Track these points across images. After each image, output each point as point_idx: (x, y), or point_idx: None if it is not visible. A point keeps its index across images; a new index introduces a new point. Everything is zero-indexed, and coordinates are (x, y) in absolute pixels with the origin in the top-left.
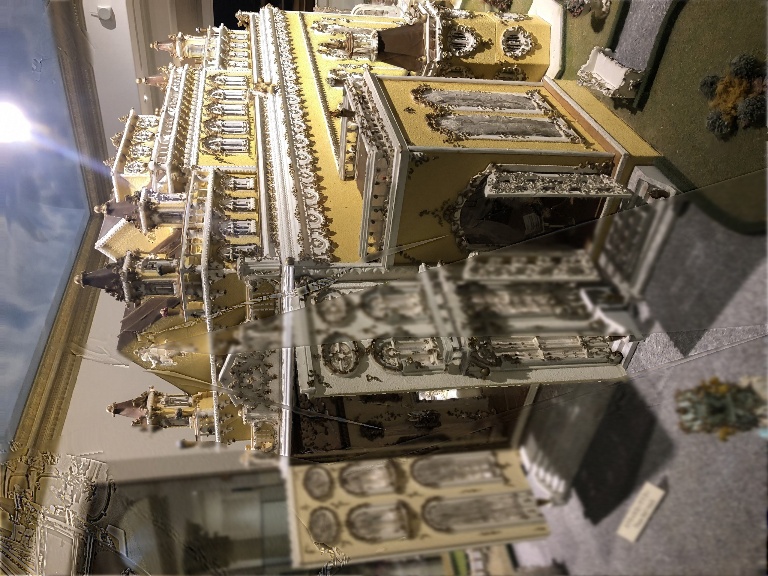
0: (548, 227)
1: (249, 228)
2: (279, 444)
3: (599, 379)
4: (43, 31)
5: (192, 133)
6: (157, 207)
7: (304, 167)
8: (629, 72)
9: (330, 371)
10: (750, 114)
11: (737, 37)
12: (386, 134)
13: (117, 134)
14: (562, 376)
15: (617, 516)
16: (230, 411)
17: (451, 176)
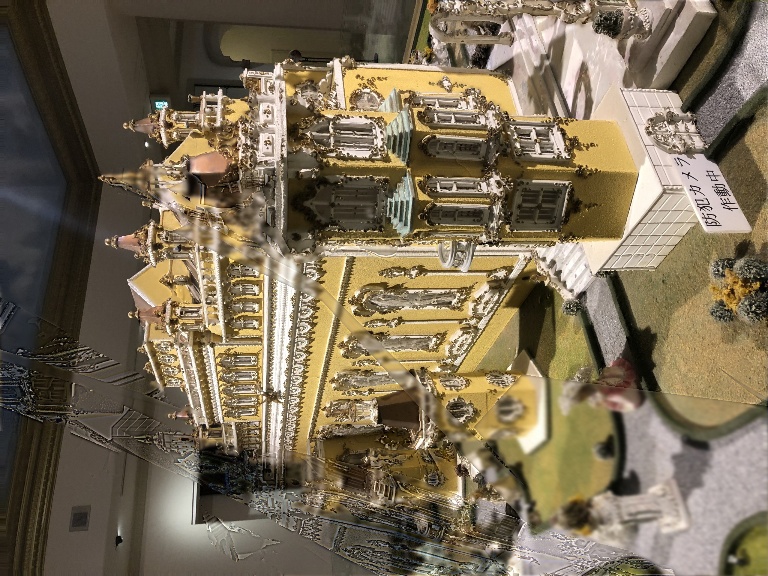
0: None
1: None
2: None
3: None
4: None
5: (215, 402)
6: None
7: None
8: None
9: None
10: None
11: None
12: None
13: None
14: None
15: (302, 566)
16: None
17: None
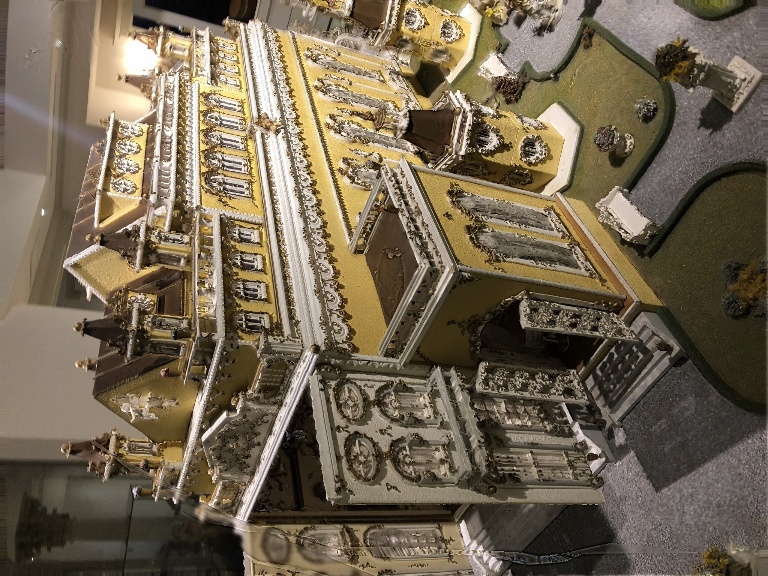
0: (545, 341)
1: (259, 292)
2: (239, 502)
3: (583, 503)
4: (49, 24)
5: (191, 162)
6: (157, 247)
7: (316, 232)
8: (650, 225)
9: (353, 477)
10: (767, 310)
11: (763, 236)
12: (434, 245)
13: (100, 140)
14: (554, 498)
15: None
16: (197, 466)
17: (486, 296)
